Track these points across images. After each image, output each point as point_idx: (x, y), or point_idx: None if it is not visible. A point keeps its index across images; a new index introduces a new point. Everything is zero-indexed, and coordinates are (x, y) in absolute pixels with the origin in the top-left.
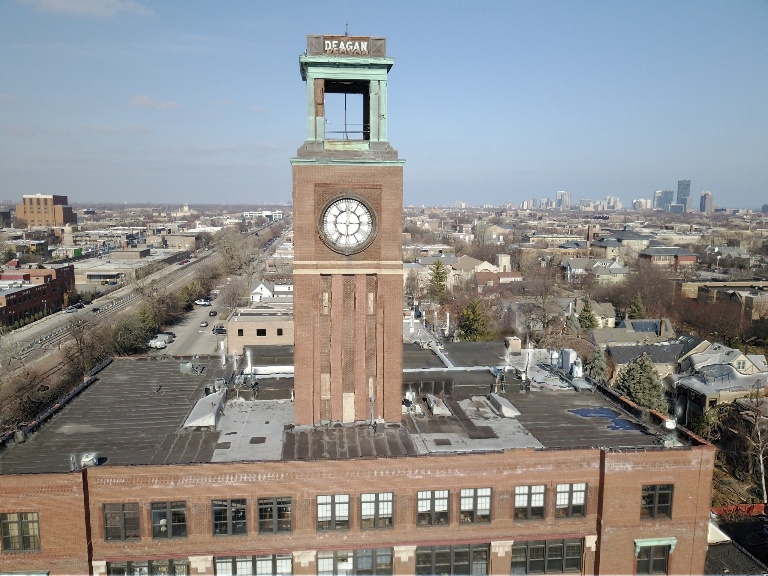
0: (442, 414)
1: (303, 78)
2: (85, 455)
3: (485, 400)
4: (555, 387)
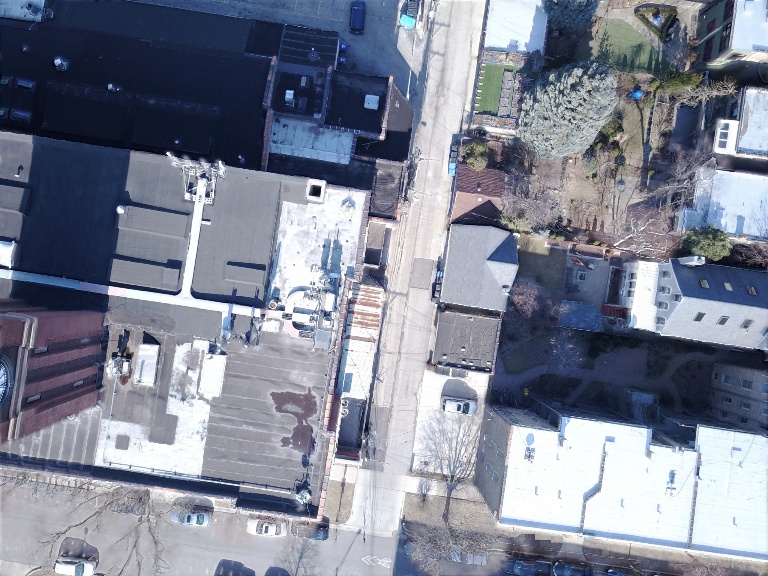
0: (144, 384)
1: None
2: None
3: (206, 348)
4: (293, 335)
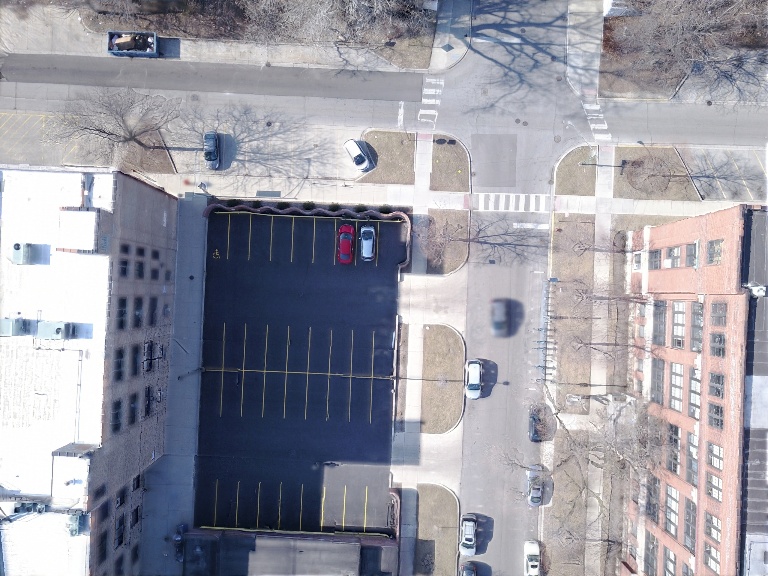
0: None
1: None
2: (763, 288)
3: None
4: None
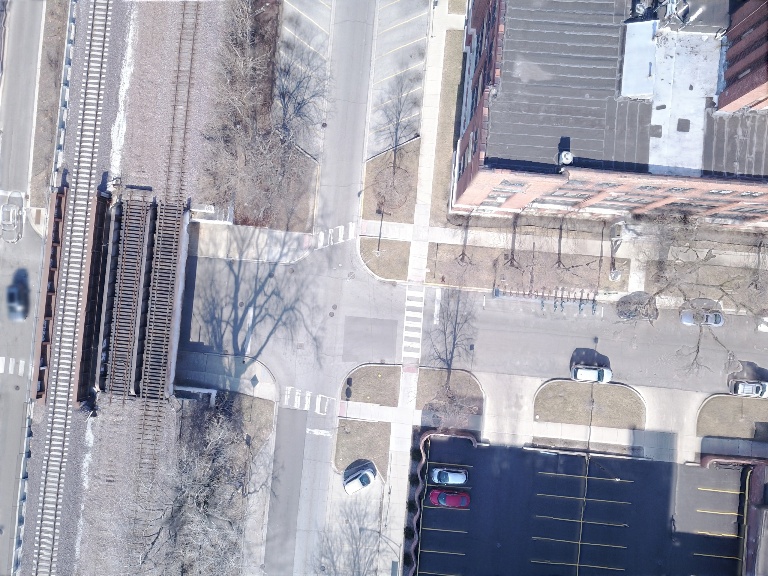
0: None
1: None
2: (564, 154)
3: None
4: None
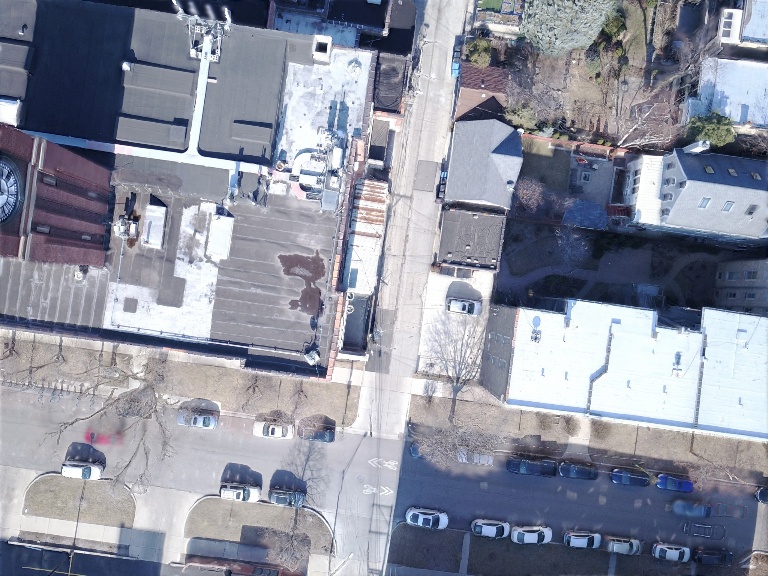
0: (151, 246)
1: None
2: None
3: (213, 211)
4: (300, 196)
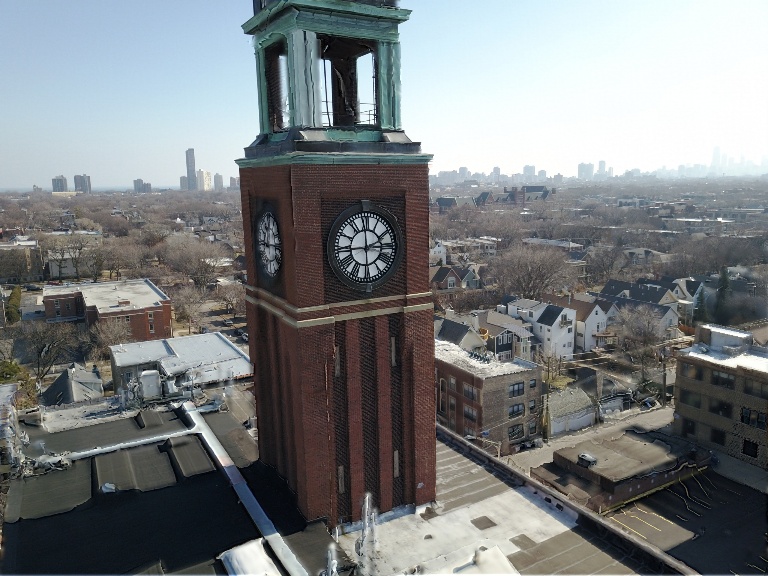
0: None
1: (311, 4)
2: None
3: None
4: None
